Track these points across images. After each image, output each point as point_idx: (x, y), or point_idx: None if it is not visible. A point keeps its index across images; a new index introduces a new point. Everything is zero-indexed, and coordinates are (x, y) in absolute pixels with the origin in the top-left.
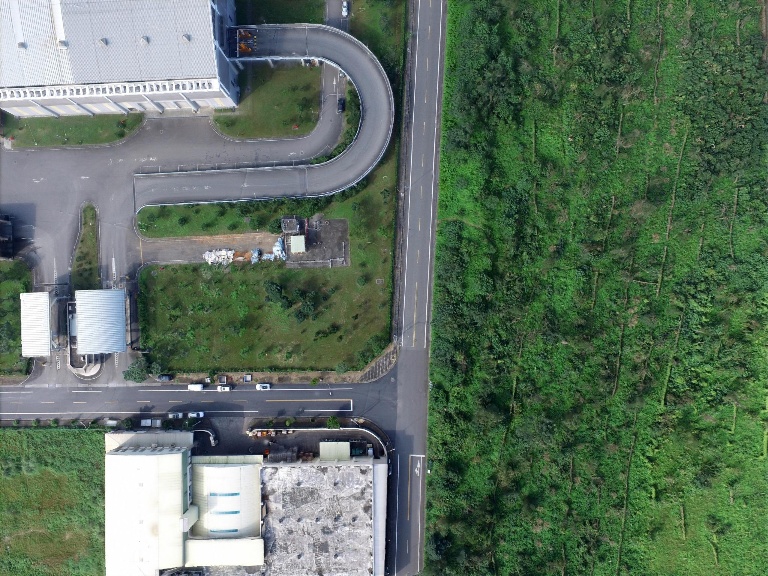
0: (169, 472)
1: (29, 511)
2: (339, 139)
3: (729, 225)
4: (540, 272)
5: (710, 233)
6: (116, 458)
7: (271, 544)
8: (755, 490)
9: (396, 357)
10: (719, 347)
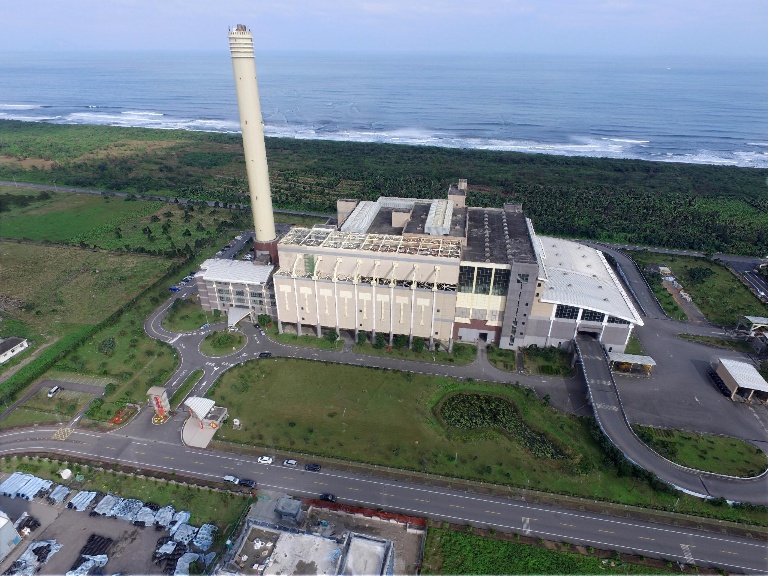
0: None
1: None
2: None
3: None
4: None
5: None
6: None
7: None
8: None
9: None
10: None
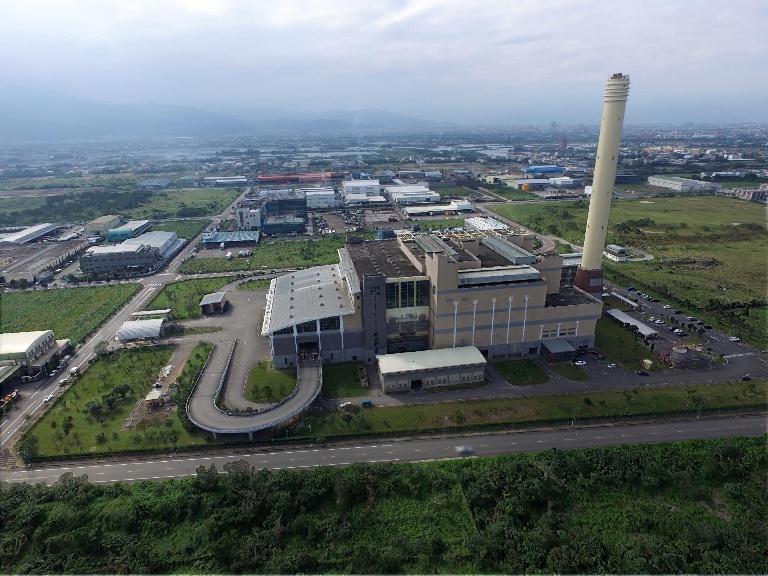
0: (16, 348)
1: (47, 328)
2: None
3: None
4: None
5: None
6: None
7: None
8: None
9: (7, 469)
10: None
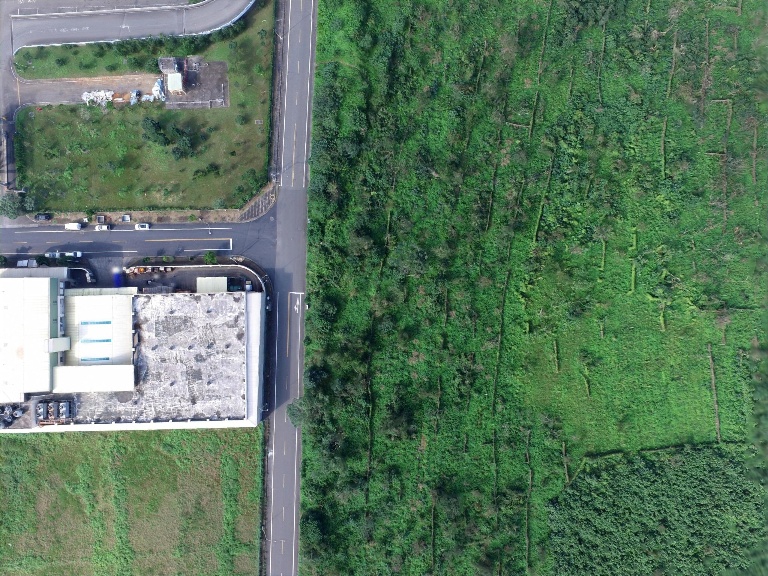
0: (35, 295)
1: None
2: None
3: (597, 71)
4: (414, 111)
5: (579, 79)
6: None
7: (143, 373)
8: (624, 324)
9: (275, 196)
10: (588, 187)
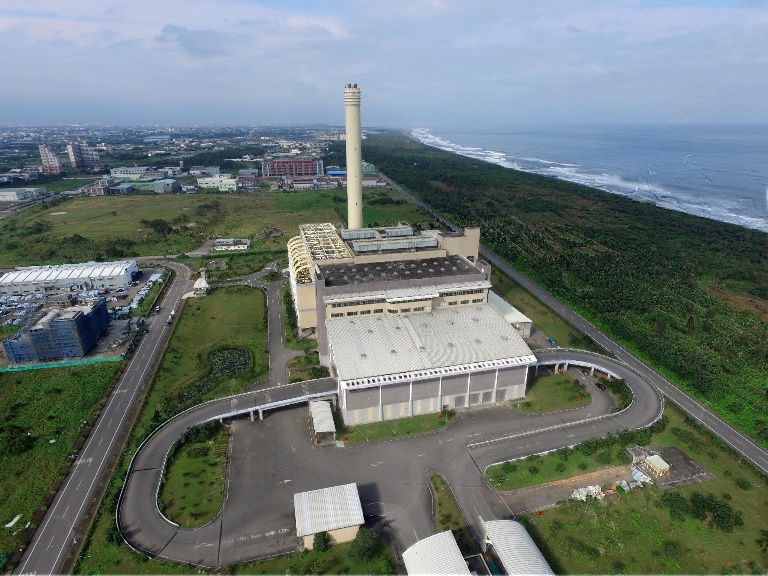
0: None
1: None
2: (616, 403)
3: None
4: None
5: None
6: None
7: None
8: None
9: None
10: None
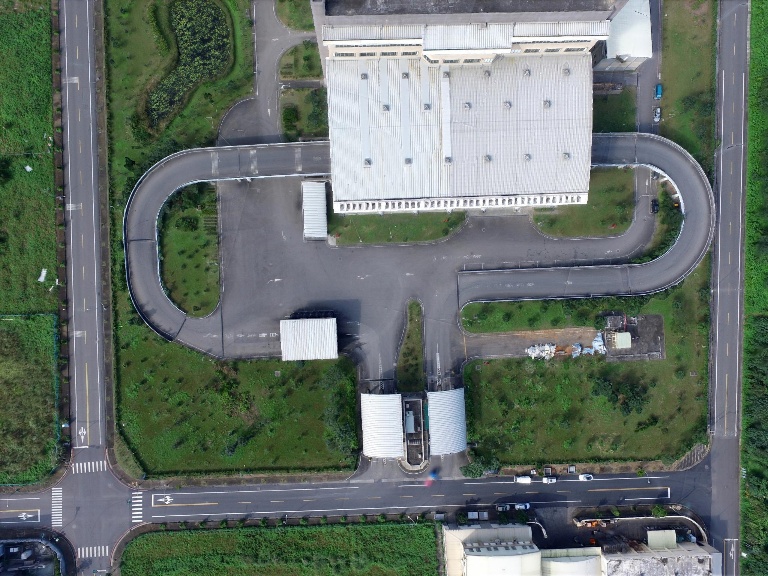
0: (531, 571)
1: None
2: (652, 238)
3: None
4: None
5: None
6: (479, 559)
7: None
8: None
9: (710, 446)
10: None
